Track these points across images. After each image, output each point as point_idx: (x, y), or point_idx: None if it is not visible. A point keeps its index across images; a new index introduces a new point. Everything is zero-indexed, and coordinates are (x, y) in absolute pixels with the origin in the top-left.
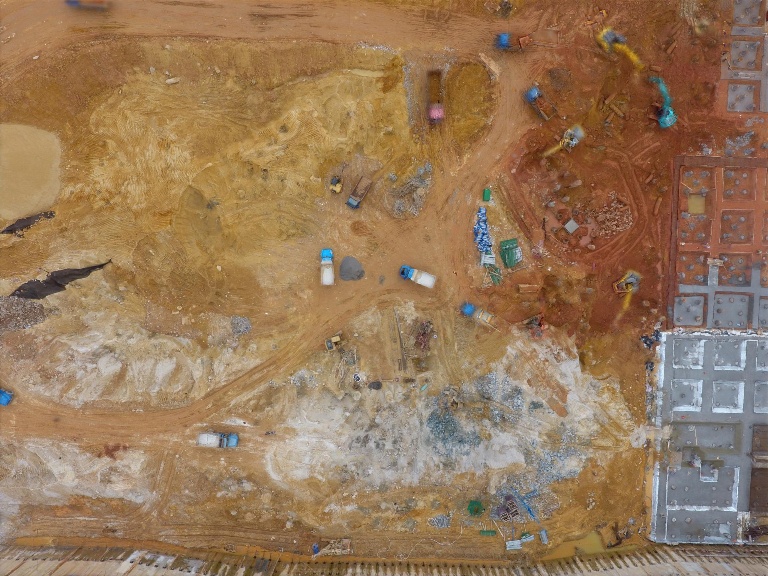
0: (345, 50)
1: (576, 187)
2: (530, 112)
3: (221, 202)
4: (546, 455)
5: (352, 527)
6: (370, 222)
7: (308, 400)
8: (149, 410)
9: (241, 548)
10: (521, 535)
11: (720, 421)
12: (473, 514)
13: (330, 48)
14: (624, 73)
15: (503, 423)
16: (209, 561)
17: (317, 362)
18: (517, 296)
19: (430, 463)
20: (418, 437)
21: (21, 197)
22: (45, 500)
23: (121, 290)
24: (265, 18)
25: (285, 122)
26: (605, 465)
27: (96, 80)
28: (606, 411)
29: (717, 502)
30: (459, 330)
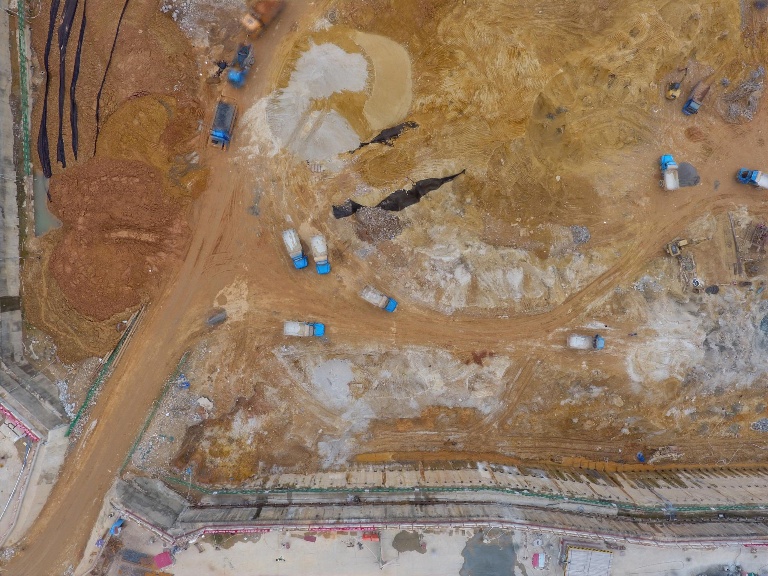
0: None
1: None
2: None
3: (569, 109)
4: None
5: (679, 434)
6: (704, 128)
7: (660, 303)
8: (513, 316)
9: (566, 459)
10: None
11: None
12: None
13: None
14: None
15: None
16: (548, 470)
17: (658, 268)
18: None
19: (764, 365)
20: (752, 340)
21: (388, 106)
22: (402, 412)
23: (464, 203)
24: None
25: (635, 26)
26: None
27: None
28: None
29: None
30: None
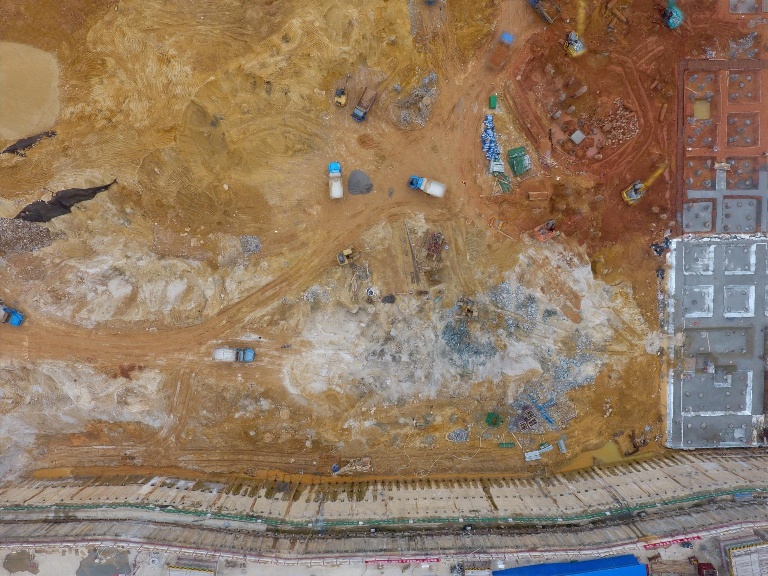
0: None
1: (581, 95)
2: (533, 16)
3: (225, 117)
4: (562, 362)
5: (371, 445)
6: (376, 134)
7: (323, 314)
8: (163, 329)
9: (261, 472)
10: (540, 445)
11: (732, 326)
12: (491, 427)
13: None
14: None
15: (518, 333)
16: (230, 484)
17: (329, 277)
18: (527, 203)
19: (447, 375)
20: (434, 350)
21: (21, 116)
22: (62, 427)
23: (127, 213)
24: None
25: (286, 31)
26: (621, 370)
27: None
28: (620, 316)
29: (731, 407)
30: (470, 240)
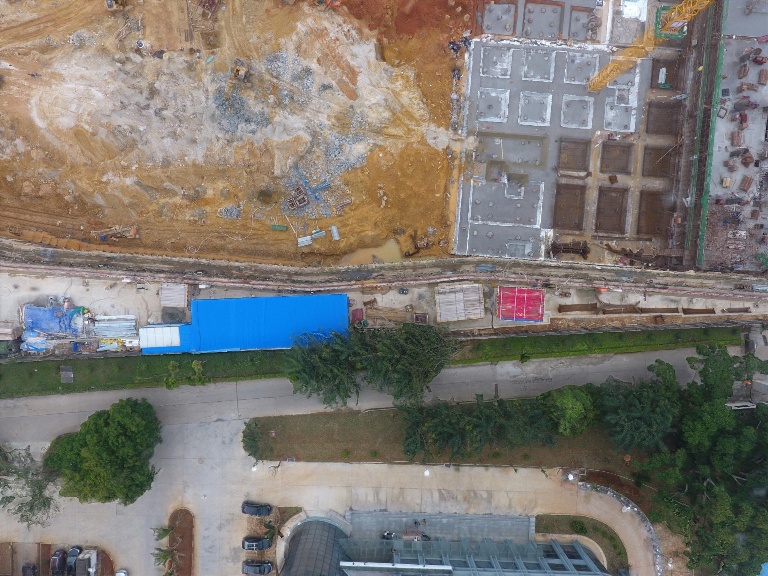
0: None
1: None
2: None
3: None
4: (333, 137)
5: (139, 213)
6: None
7: (81, 53)
8: None
9: (27, 233)
10: (312, 230)
11: (526, 133)
12: (264, 207)
13: None
14: None
15: (293, 105)
16: None
17: (99, 24)
18: None
19: None
20: (203, 113)
21: None
22: None
23: None
24: None
25: None
26: (395, 154)
27: None
28: (398, 98)
29: (522, 220)
30: (249, 3)
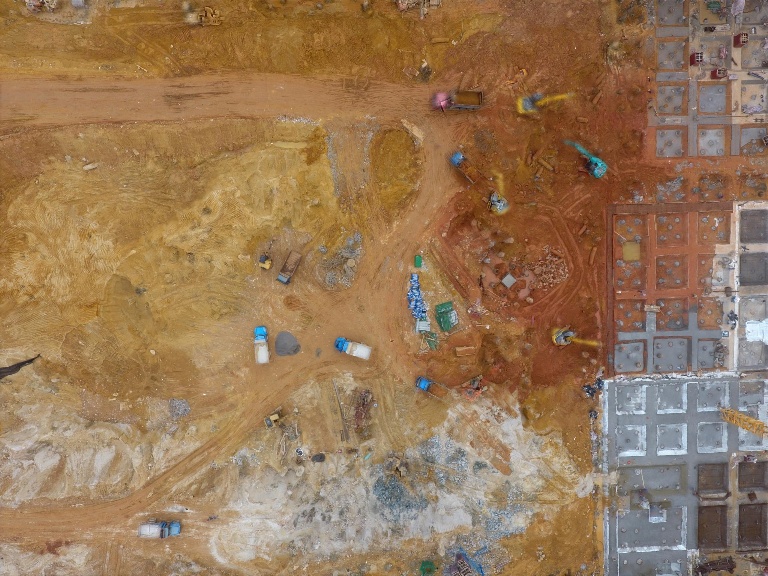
0: (265, 125)
1: (510, 243)
2: (456, 175)
3: (148, 288)
4: (493, 514)
5: None
6: (303, 296)
7: (250, 480)
8: (89, 504)
9: None
10: None
11: (665, 463)
12: (426, 574)
13: (249, 124)
14: (550, 128)
15: (449, 485)
16: None
17: (258, 440)
18: (454, 360)
19: (379, 530)
20: (365, 505)
21: None
22: None
23: (54, 381)
24: (180, 98)
25: (207, 204)
26: (552, 519)
27: (10, 173)
28: (550, 466)
29: (667, 541)
30: (399, 397)
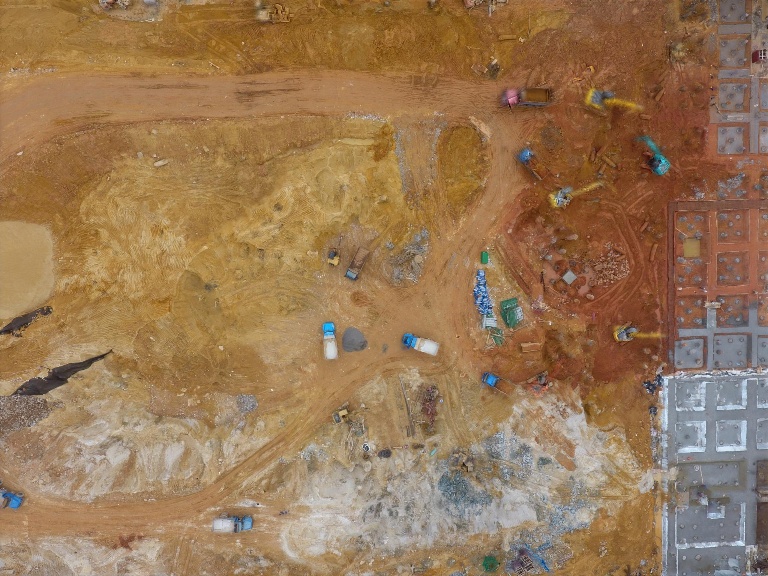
0: (334, 121)
1: (572, 240)
2: (523, 172)
3: (219, 284)
4: (557, 510)
5: None
6: (370, 292)
7: (319, 475)
8: (161, 498)
9: None
10: None
11: (724, 460)
12: (488, 569)
13: (319, 120)
14: (614, 125)
15: (513, 480)
16: None
17: (326, 435)
18: (520, 356)
19: (444, 525)
20: (430, 501)
21: (16, 296)
22: None
23: (124, 377)
24: (251, 95)
25: (278, 201)
26: (615, 514)
27: (83, 169)
28: (613, 462)
29: (725, 537)
30: (465, 393)
